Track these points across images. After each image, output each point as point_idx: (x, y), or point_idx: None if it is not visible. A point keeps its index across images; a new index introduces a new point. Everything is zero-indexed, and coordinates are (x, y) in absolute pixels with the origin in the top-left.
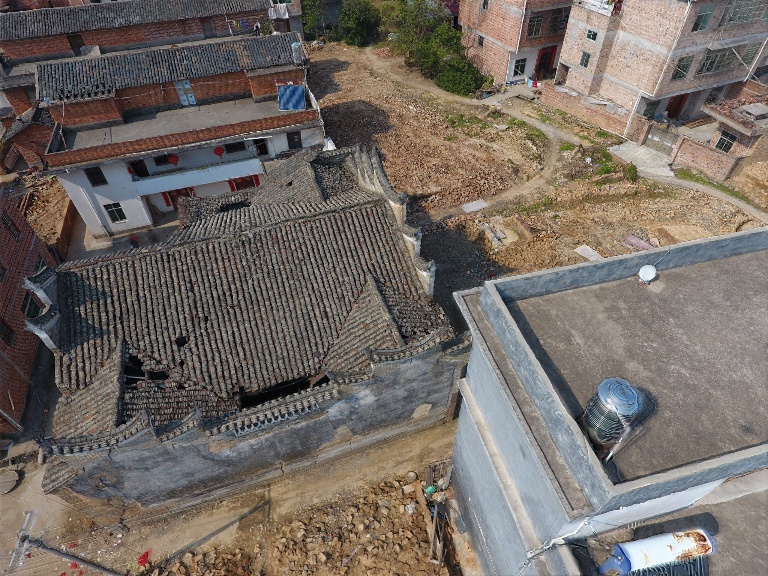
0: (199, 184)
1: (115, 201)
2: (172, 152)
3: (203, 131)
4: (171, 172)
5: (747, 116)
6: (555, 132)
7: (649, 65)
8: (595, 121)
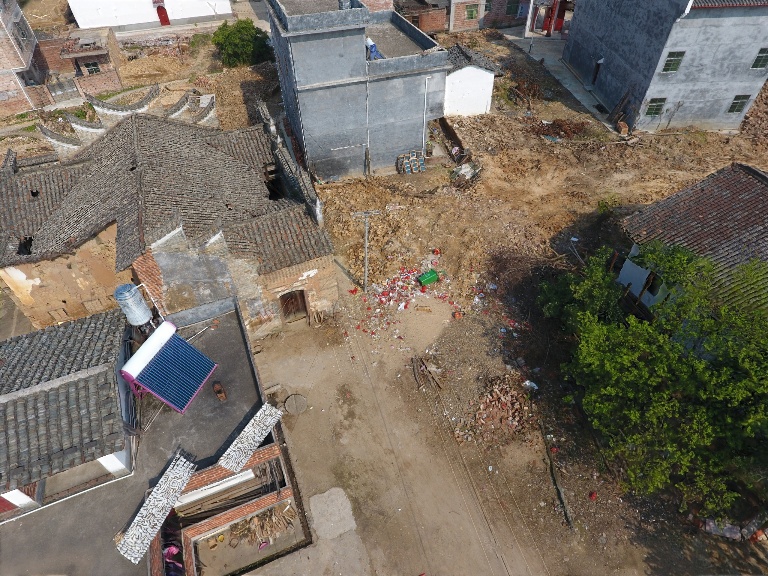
0: None
1: None
2: None
3: None
4: None
5: None
6: None
7: None
8: None
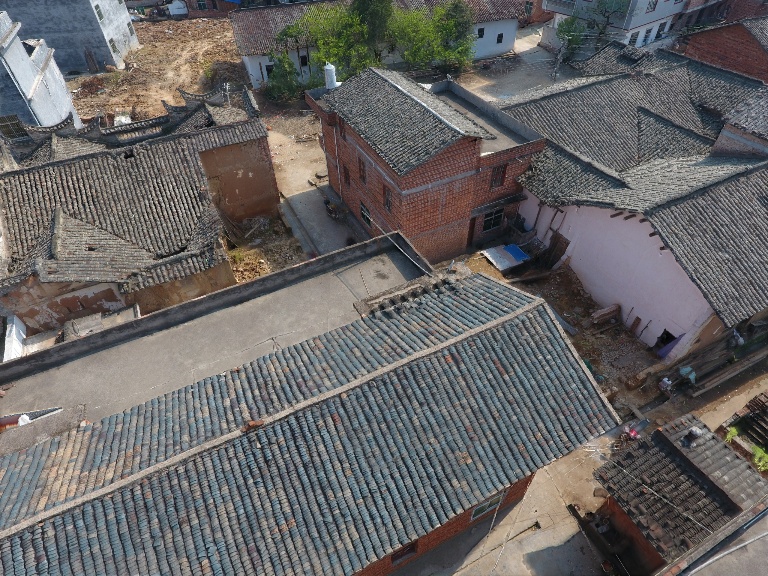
0: None
1: None
2: None
3: (199, 300)
4: None
5: None
6: None
7: None
8: None
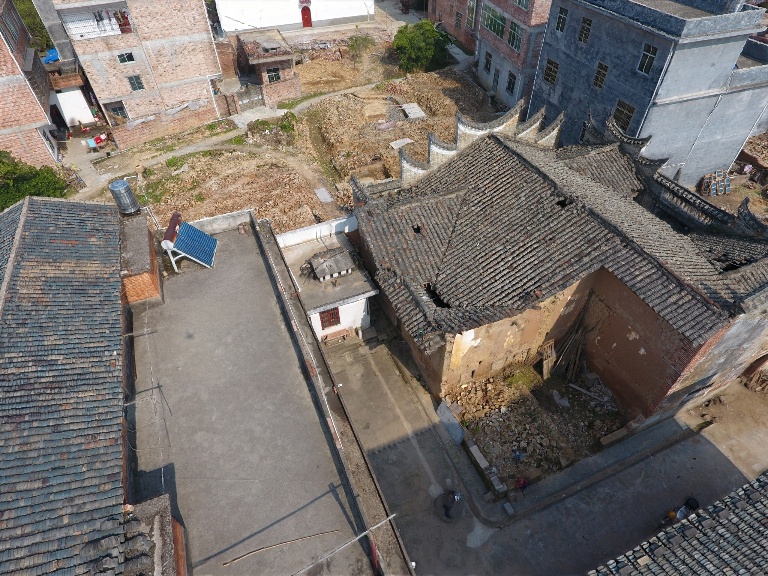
0: None
1: None
2: None
3: None
4: None
5: (274, 51)
6: (198, 146)
7: (198, 53)
8: (188, 126)
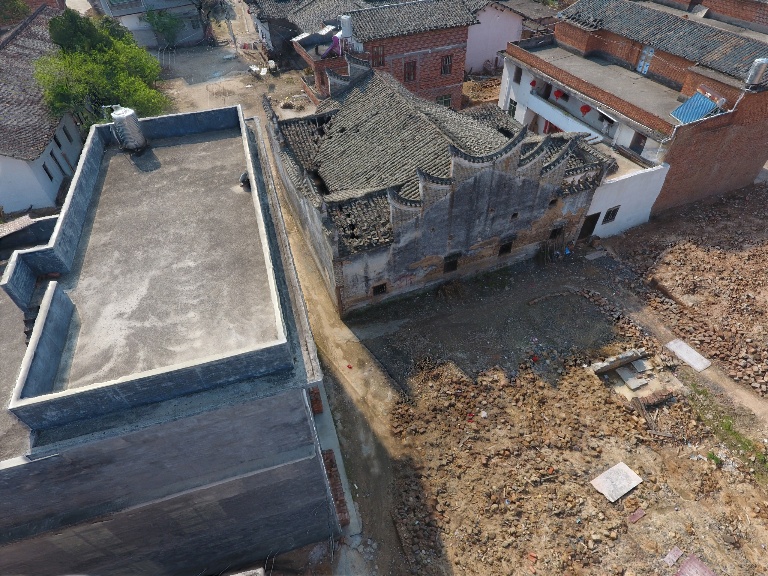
0: (558, 126)
1: (516, 100)
2: (554, 84)
3: (584, 83)
4: (551, 103)
5: None
6: None
7: None
8: None
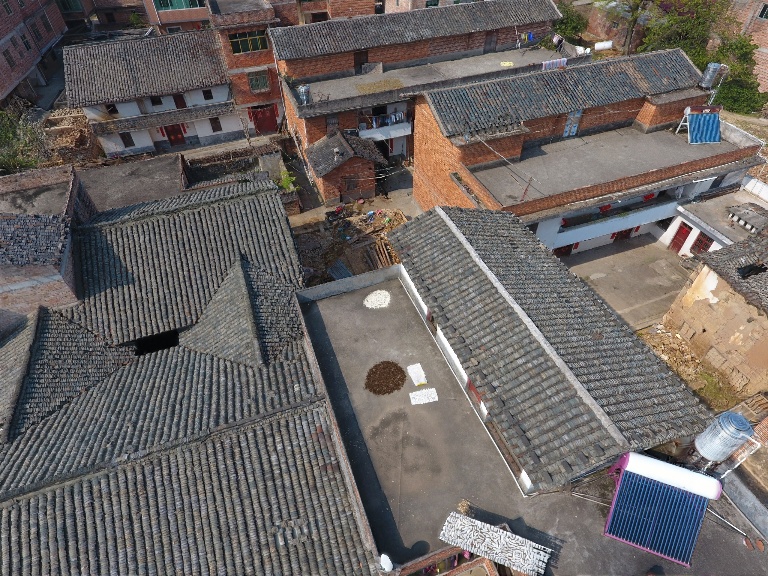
0: (610, 233)
1: None
2: (623, 199)
3: (653, 173)
4: (594, 220)
5: None
6: None
7: None
8: None
